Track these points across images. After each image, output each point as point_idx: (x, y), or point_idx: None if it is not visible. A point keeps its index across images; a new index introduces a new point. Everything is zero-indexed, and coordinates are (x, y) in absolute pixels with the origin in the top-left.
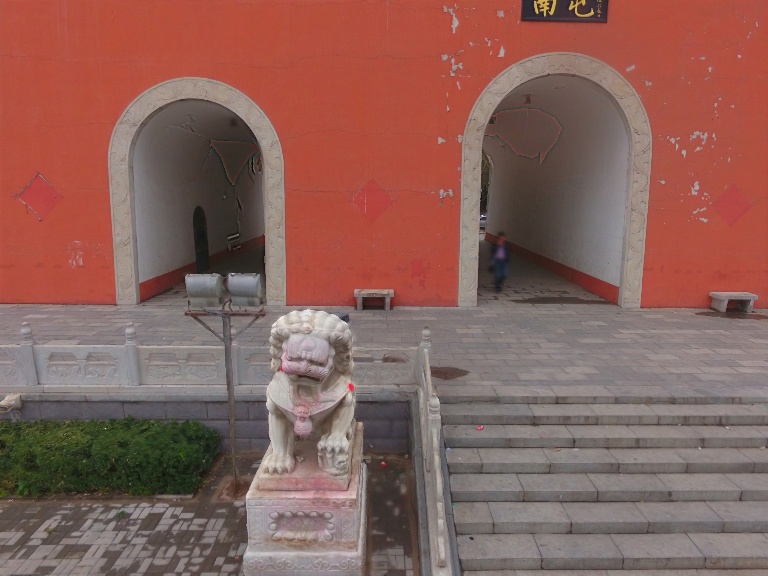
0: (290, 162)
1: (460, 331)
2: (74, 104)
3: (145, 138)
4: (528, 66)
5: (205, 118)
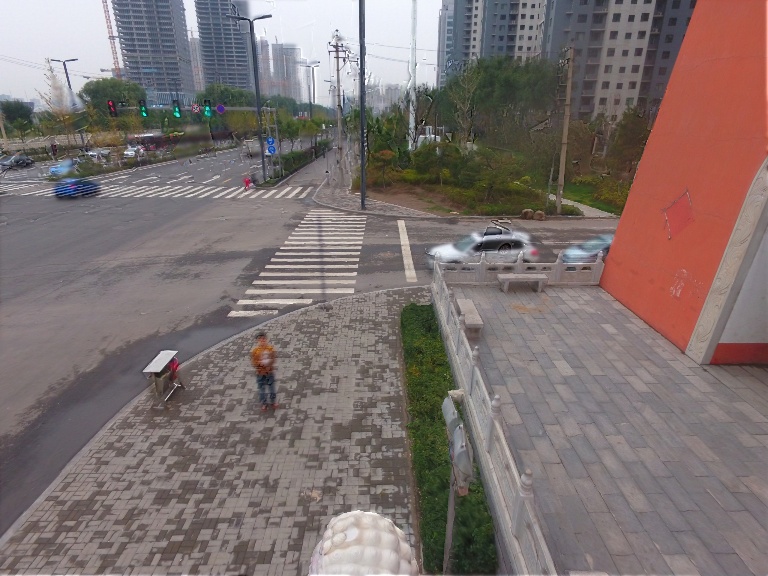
0: None
1: None
2: (751, 112)
3: None
4: None
5: None
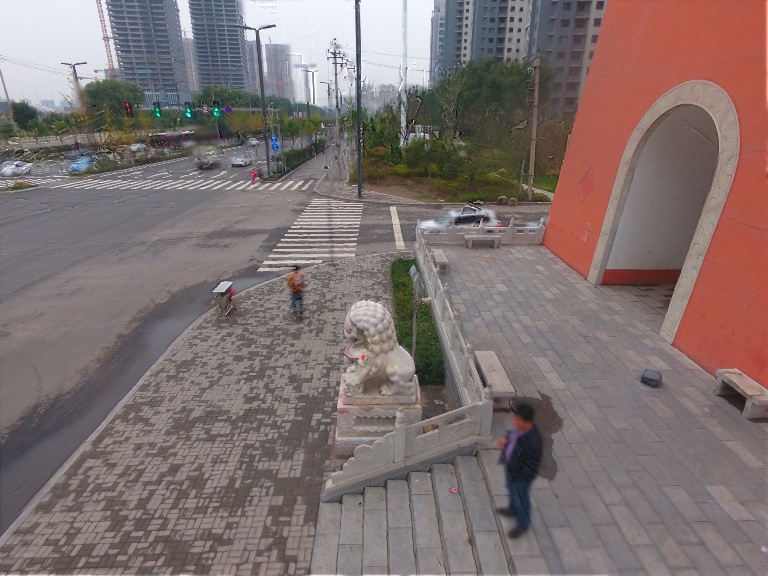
0: (740, 182)
1: (713, 489)
2: (623, 112)
3: (659, 141)
4: None
5: (696, 123)
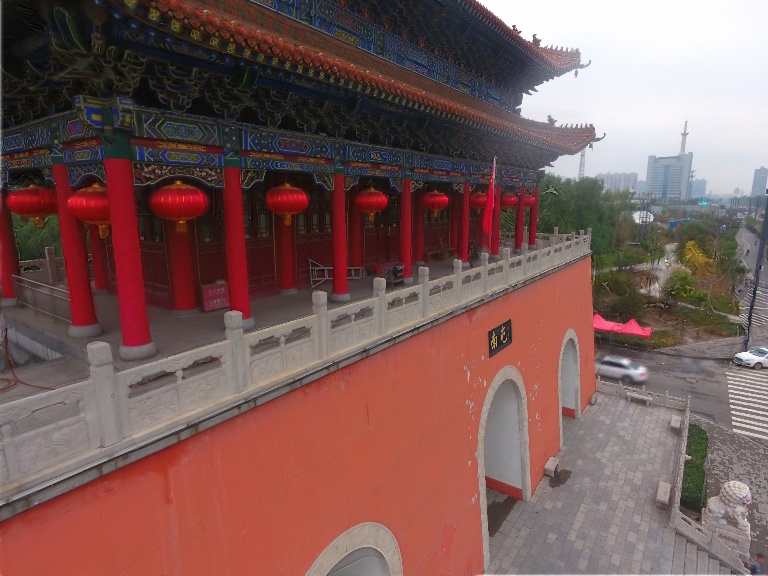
0: (404, 556)
1: None
2: None
3: None
4: (494, 385)
5: None
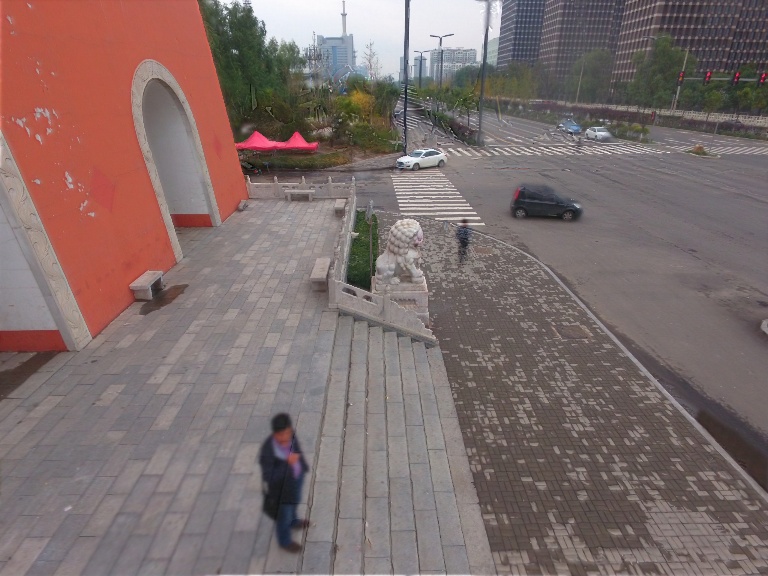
0: None
1: None
2: None
3: None
4: None
5: None
